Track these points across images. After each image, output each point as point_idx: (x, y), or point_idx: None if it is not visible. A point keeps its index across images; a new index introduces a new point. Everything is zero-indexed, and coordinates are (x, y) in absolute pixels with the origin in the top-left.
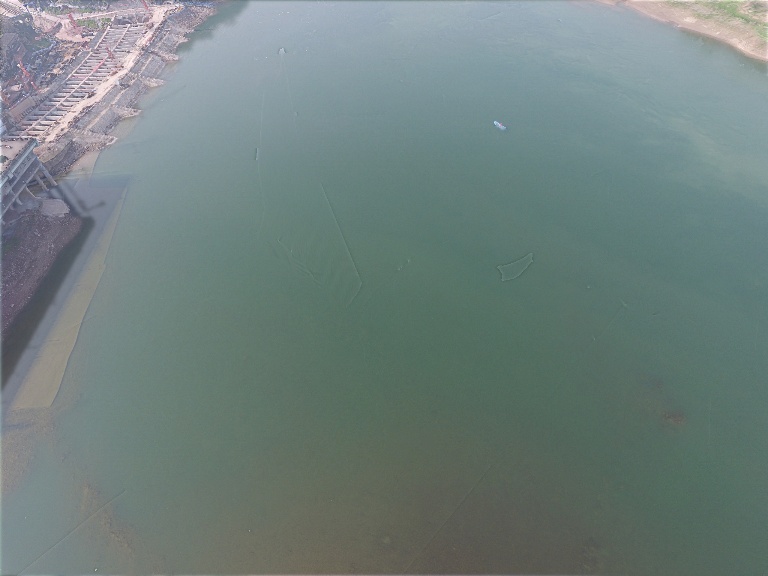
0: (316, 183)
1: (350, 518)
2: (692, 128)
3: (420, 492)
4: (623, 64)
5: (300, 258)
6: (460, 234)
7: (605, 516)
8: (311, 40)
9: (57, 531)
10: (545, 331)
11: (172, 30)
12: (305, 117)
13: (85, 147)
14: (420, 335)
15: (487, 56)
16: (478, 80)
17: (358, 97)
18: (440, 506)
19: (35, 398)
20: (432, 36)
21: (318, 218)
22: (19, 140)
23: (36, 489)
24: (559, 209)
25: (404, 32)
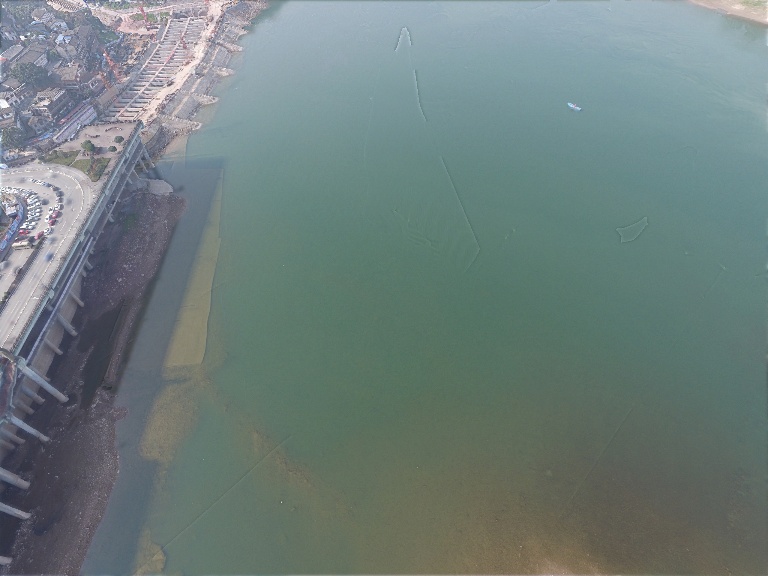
0: (435, 155)
1: (509, 455)
2: (759, 108)
3: (570, 432)
4: (680, 49)
5: (417, 227)
6: (553, 207)
7: (750, 449)
8: (369, 31)
9: (237, 470)
10: (656, 291)
11: (231, 23)
12: None
13: (174, 132)
14: (534, 298)
15: (544, 44)
16: (541, 66)
17: (428, 83)
18: (592, 443)
19: (185, 356)
20: (488, 25)
21: (435, 188)
22: (127, 122)
23: (207, 435)
24: (648, 182)
25: (461, 22)
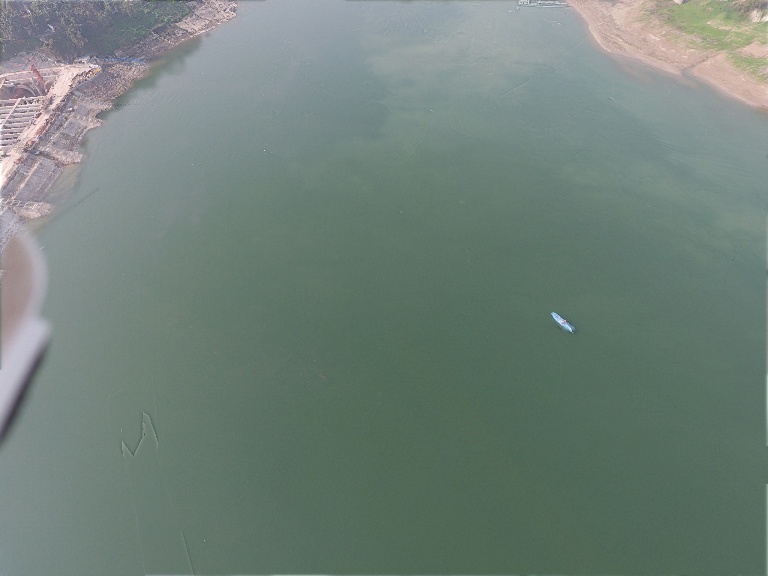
0: None
1: None
2: None
3: None
4: (717, 185)
5: None
6: None
7: None
8: (272, 130)
9: None
10: None
11: (79, 108)
12: (255, 295)
13: None
14: None
15: (520, 163)
16: (513, 214)
17: (337, 248)
18: None
19: None
20: (441, 126)
21: None
22: None
23: None
24: (701, 571)
25: (402, 121)
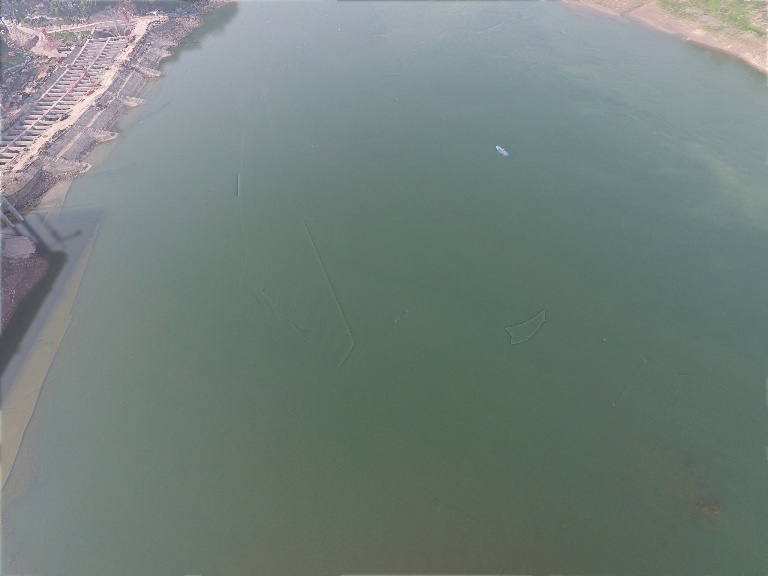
0: (302, 230)
1: None
2: (708, 153)
3: None
4: (631, 81)
5: (285, 313)
6: (462, 276)
7: None
8: (301, 54)
9: None
10: (559, 396)
11: (155, 44)
12: (294, 141)
13: (56, 176)
14: (419, 399)
15: (487, 72)
16: (478, 99)
17: (351, 118)
18: None
19: None
20: (429, 50)
21: (305, 269)
22: None
23: None
24: (570, 249)
25: (399, 46)
